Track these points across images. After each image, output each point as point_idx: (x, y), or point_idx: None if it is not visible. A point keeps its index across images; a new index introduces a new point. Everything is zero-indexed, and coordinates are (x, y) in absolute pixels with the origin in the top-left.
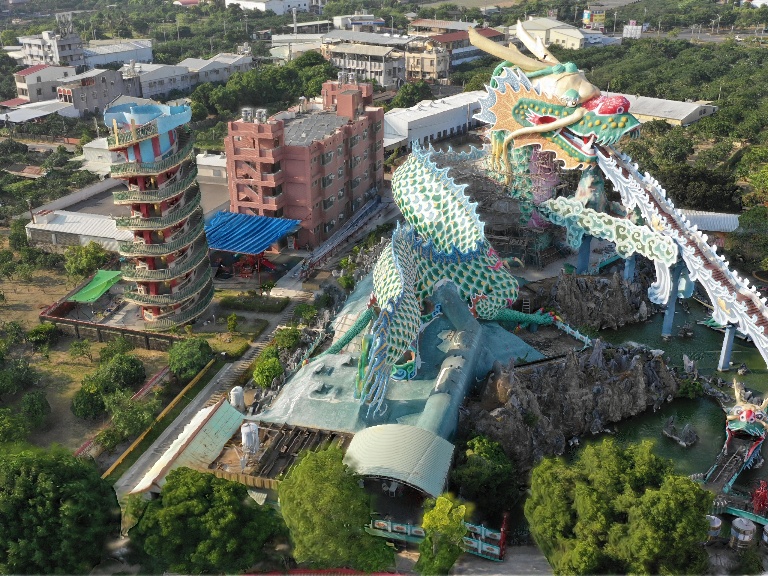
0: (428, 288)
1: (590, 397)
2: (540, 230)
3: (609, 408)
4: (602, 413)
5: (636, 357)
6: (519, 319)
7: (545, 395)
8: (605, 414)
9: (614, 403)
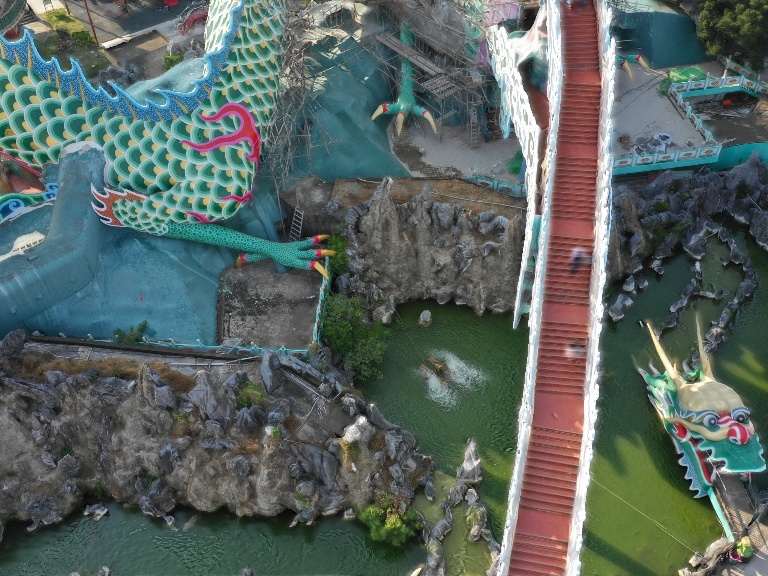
0: (48, 150)
1: (152, 457)
2: (481, 76)
3: (187, 487)
4: (176, 488)
5: (266, 431)
6: (236, 246)
7: (55, 424)
8: (183, 491)
9: (191, 486)
